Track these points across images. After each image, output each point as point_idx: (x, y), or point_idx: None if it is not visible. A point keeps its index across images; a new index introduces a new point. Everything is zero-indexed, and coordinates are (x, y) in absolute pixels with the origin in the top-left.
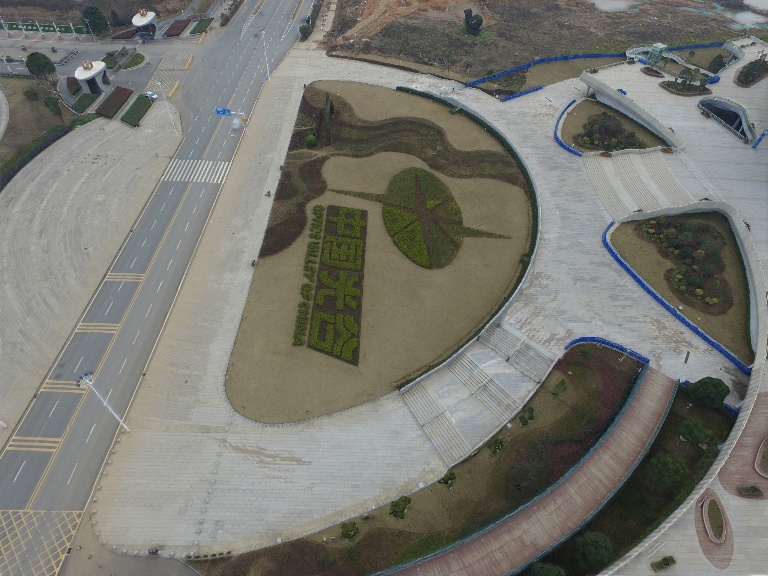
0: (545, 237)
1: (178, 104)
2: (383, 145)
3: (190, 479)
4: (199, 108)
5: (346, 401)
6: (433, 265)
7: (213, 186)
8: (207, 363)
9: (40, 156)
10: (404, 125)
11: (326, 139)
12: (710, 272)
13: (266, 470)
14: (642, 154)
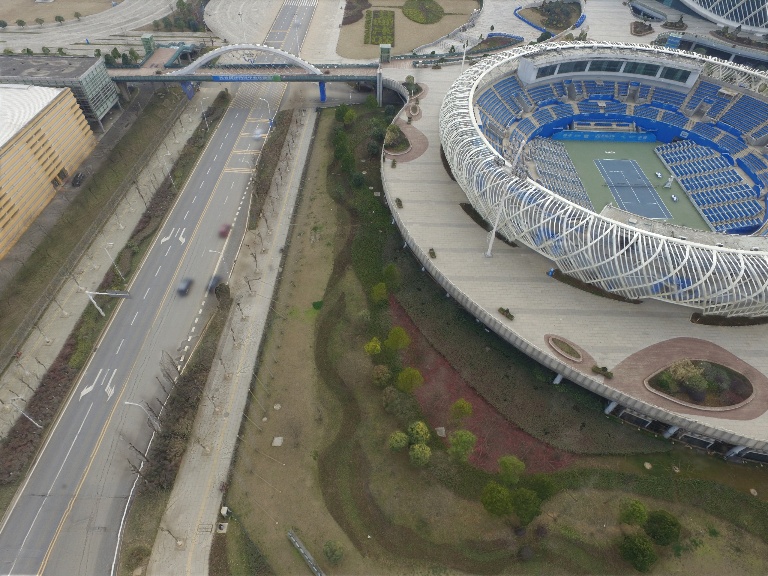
0: (485, 12)
1: None
2: None
3: None
4: None
5: None
6: (428, 23)
7: (311, 7)
8: None
9: None
10: None
11: None
12: None
13: None
14: None
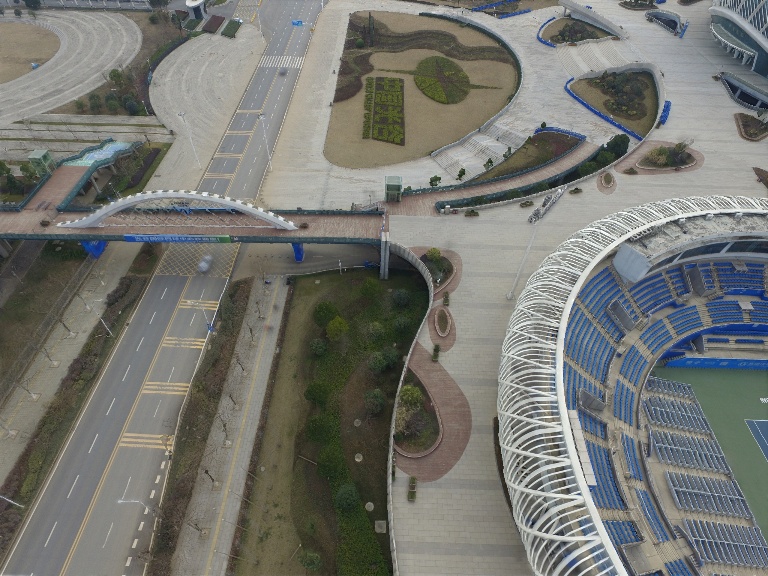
0: (525, 86)
1: (259, 26)
2: (412, 45)
3: (312, 188)
4: (274, 28)
5: (399, 160)
6: (450, 102)
7: (295, 69)
8: (311, 146)
9: (173, 53)
10: (426, 34)
11: (371, 42)
12: (633, 98)
13: (355, 185)
14: (598, 42)
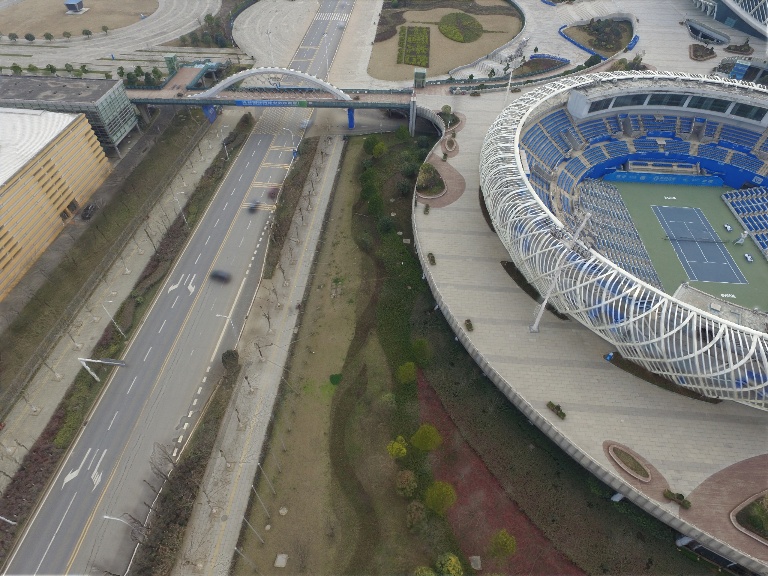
0: (527, 31)
1: None
2: (437, 6)
3: None
4: None
5: None
6: (466, 41)
7: (343, 22)
8: (357, 68)
9: (247, 10)
10: None
11: (404, 3)
12: None
13: None
14: (591, 1)
